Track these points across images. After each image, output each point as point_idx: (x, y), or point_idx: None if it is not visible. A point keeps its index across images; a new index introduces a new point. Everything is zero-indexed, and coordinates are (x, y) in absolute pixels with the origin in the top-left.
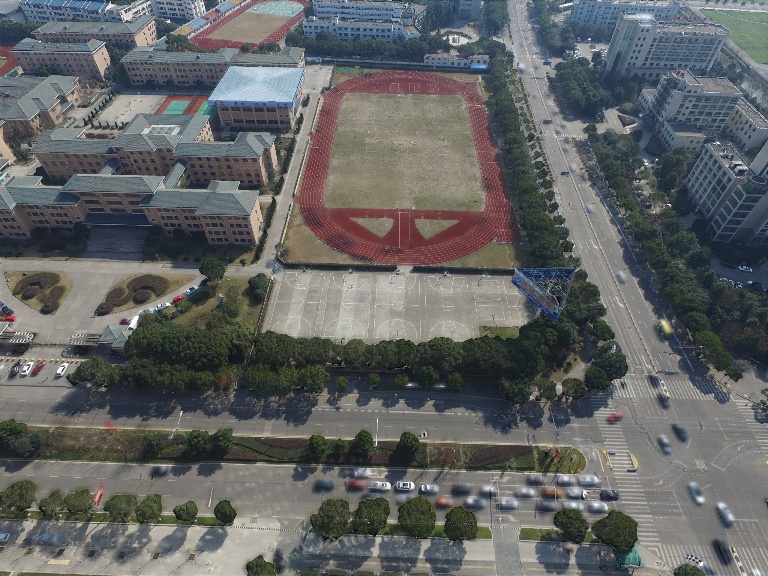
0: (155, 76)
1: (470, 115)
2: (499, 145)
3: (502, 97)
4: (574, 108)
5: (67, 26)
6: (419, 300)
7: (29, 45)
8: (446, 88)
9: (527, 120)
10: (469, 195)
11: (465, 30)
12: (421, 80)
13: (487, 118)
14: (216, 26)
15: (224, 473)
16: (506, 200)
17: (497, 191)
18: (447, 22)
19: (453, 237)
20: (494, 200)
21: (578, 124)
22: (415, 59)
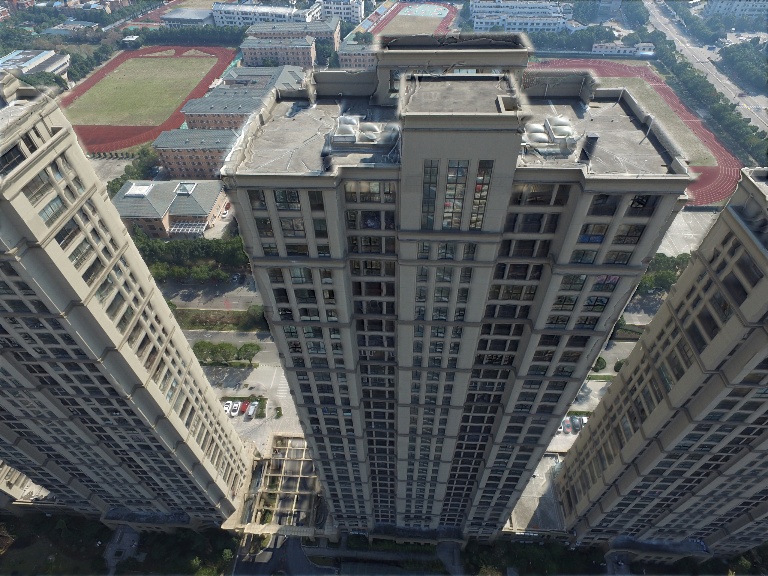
0: (363, 66)
1: (659, 93)
2: (701, 115)
3: (690, 76)
4: (755, 84)
5: (275, 26)
6: (704, 231)
7: (256, 41)
8: (623, 72)
9: (722, 94)
10: (698, 154)
11: (609, 25)
12: (596, 66)
13: (676, 95)
14: (380, 27)
15: (620, 348)
16: (734, 157)
17: (721, 151)
18: (591, 18)
19: (704, 185)
20: (723, 157)
21: (763, 98)
22: (583, 48)
